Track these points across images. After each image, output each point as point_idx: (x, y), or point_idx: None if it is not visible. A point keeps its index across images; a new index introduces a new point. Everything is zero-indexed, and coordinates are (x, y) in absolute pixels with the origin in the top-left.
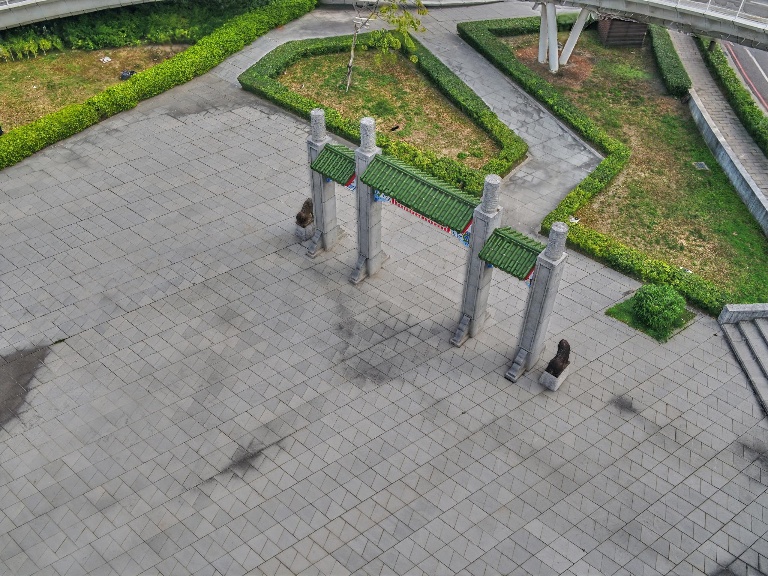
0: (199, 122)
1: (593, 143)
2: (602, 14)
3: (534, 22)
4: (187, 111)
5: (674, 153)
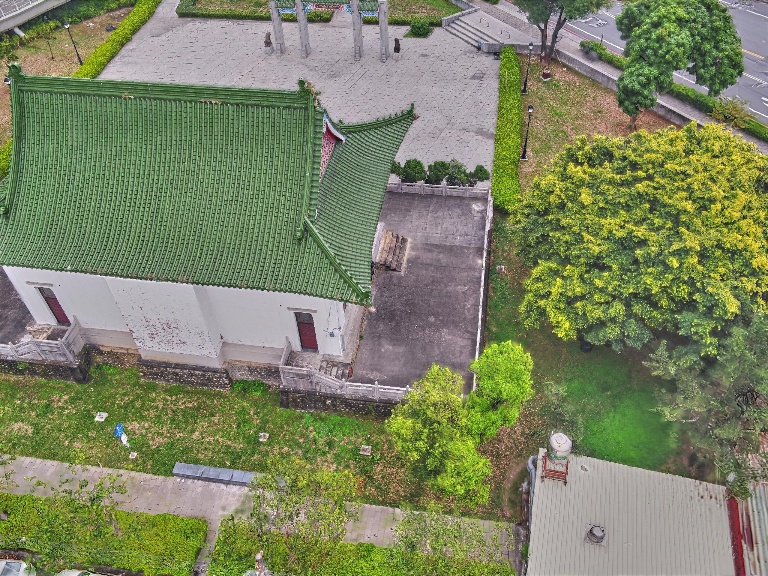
0: (173, 34)
1: None
2: None
3: None
4: (161, 33)
5: None
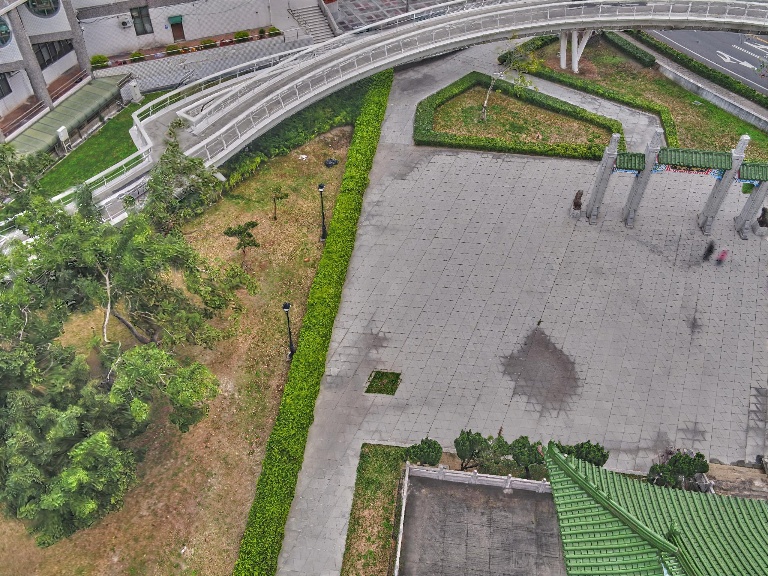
0: (422, 176)
1: (640, 109)
2: (609, 30)
3: (536, 43)
4: (404, 172)
5: (679, 100)
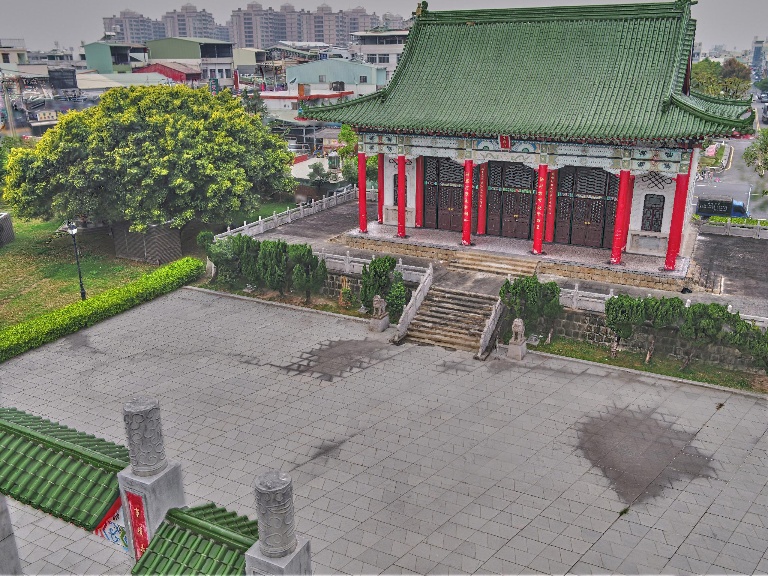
0: None
1: None
2: None
3: None
4: None
5: None
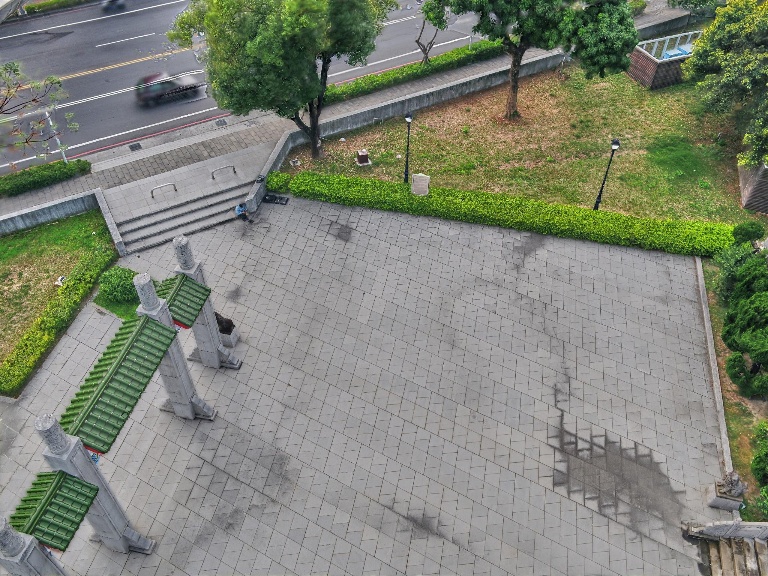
0: None
1: None
2: None
3: None
4: None
5: None
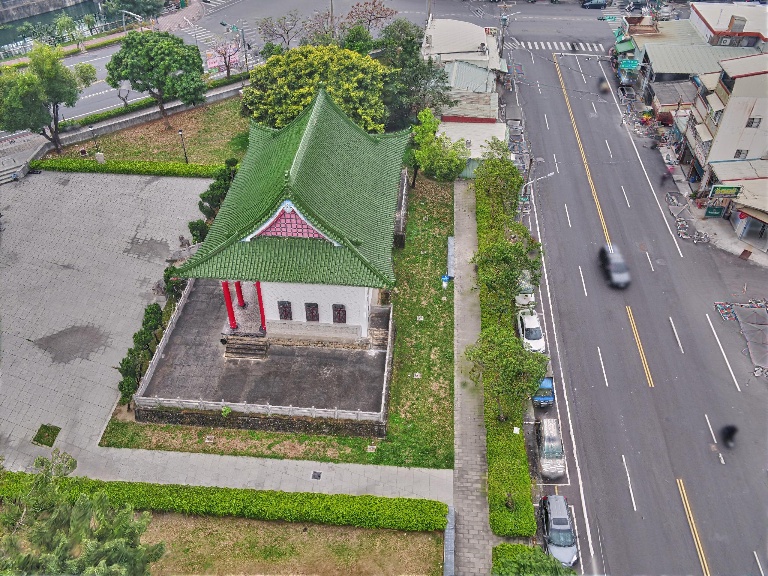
0: None
1: None
2: None
3: None
4: None
5: None
